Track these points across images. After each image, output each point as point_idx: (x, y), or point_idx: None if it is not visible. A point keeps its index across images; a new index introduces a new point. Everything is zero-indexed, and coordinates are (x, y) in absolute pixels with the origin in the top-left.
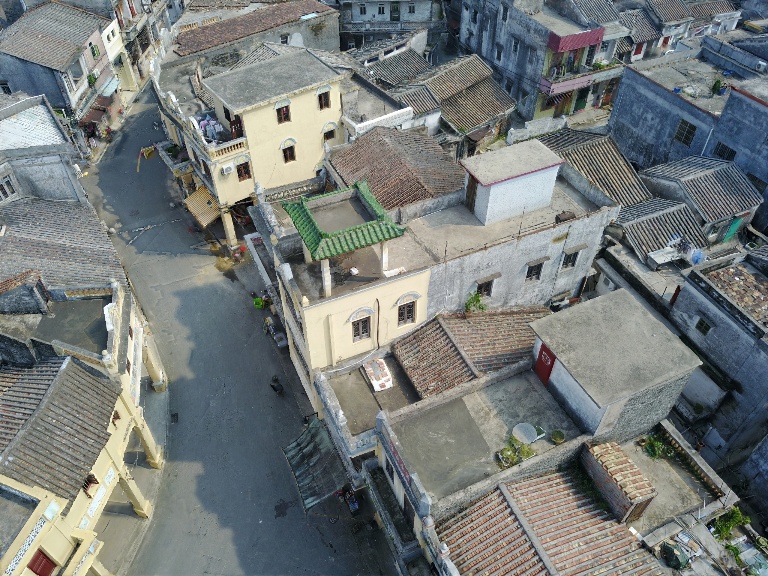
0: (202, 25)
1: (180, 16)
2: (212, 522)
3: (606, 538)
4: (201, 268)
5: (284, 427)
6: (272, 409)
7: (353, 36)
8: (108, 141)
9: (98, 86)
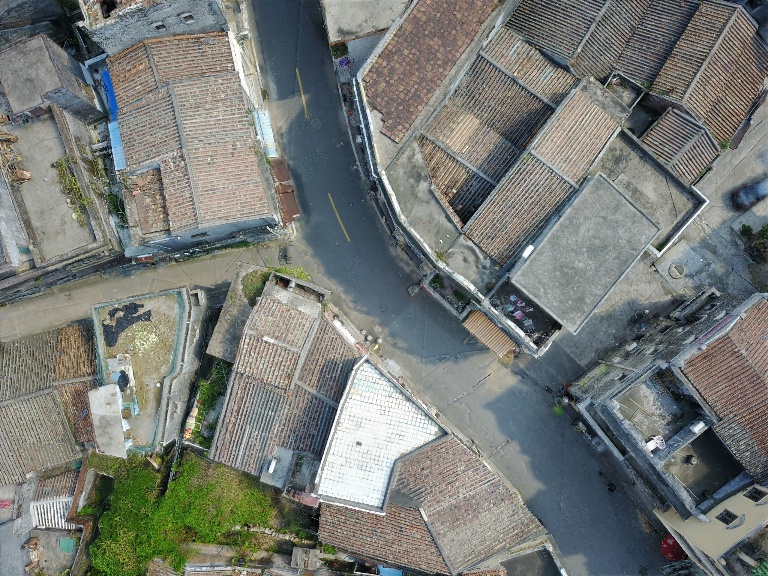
0: (382, 49)
1: (323, 8)
2: None
3: None
4: (487, 368)
5: (623, 512)
6: (608, 499)
7: None
8: None
9: None
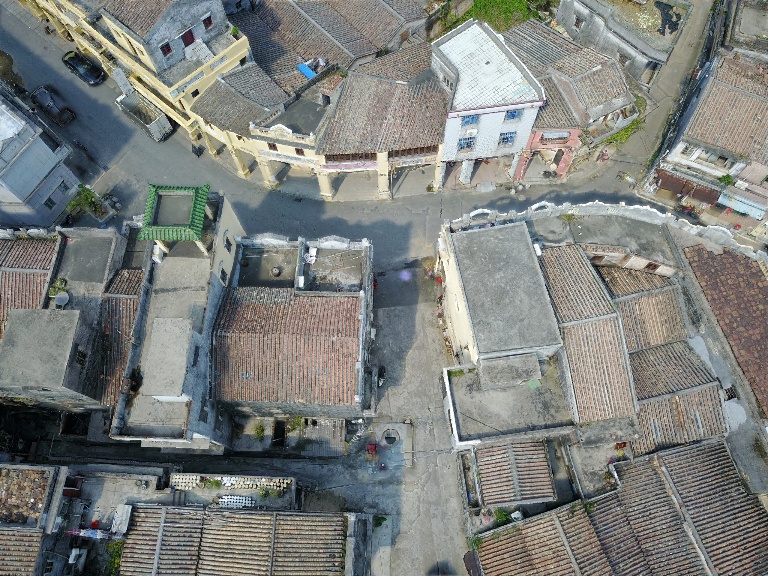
0: None
1: None
2: None
3: (6, 313)
4: (433, 246)
5: None
6: None
7: None
8: (676, 208)
9: (738, 192)
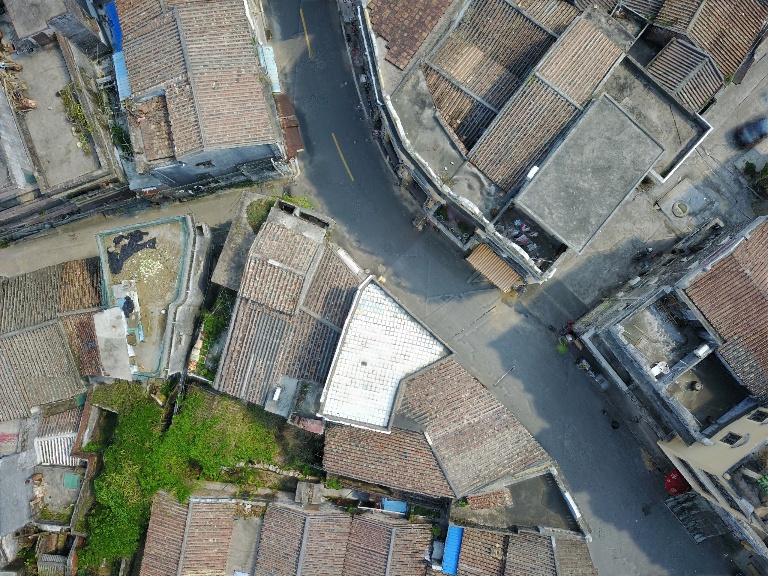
0: None
1: None
2: (605, 528)
3: None
4: (491, 307)
5: (627, 451)
6: (612, 438)
7: None
8: None
9: None
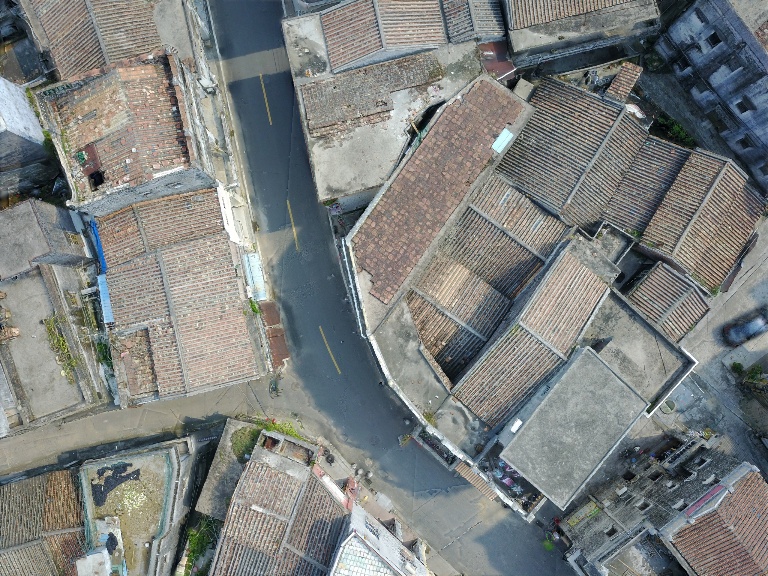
0: None
1: (312, 166)
2: None
3: None
4: (478, 502)
5: None
6: None
7: (523, 70)
8: None
9: None
